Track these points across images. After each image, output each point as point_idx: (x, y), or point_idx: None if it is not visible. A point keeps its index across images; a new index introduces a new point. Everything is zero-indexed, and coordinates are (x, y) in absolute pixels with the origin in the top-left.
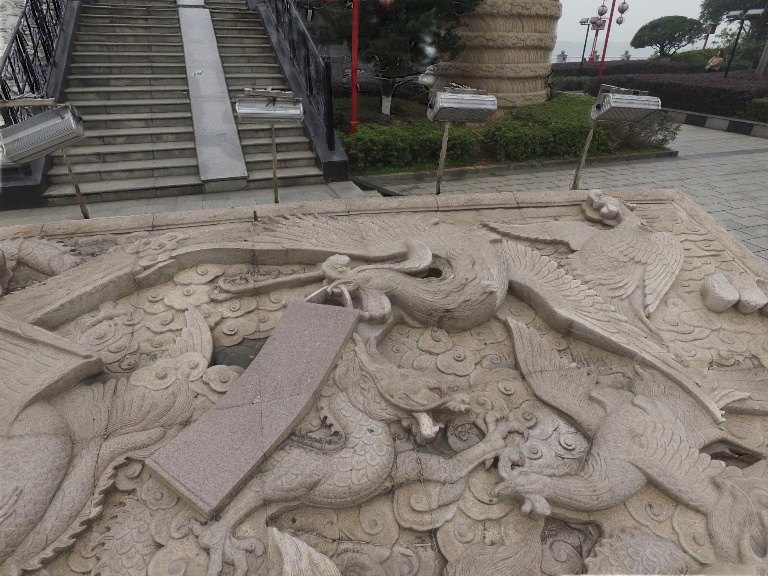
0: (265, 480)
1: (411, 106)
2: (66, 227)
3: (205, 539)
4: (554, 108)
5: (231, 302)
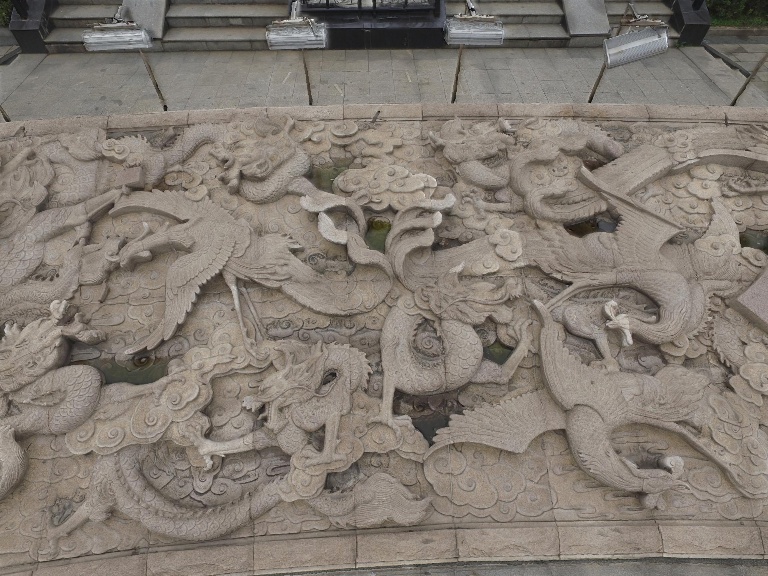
0: None
1: None
2: (591, 111)
3: None
4: None
5: (735, 199)
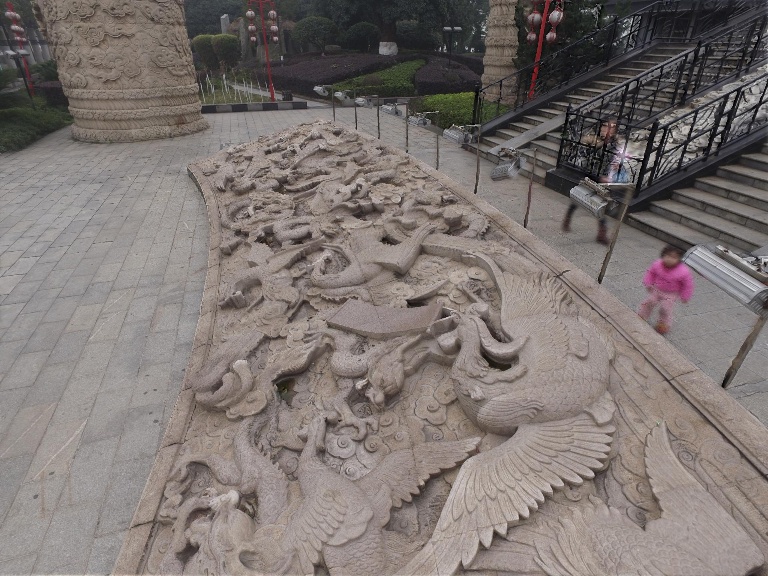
0: (341, 334)
1: None
2: (505, 222)
3: None
4: None
5: None
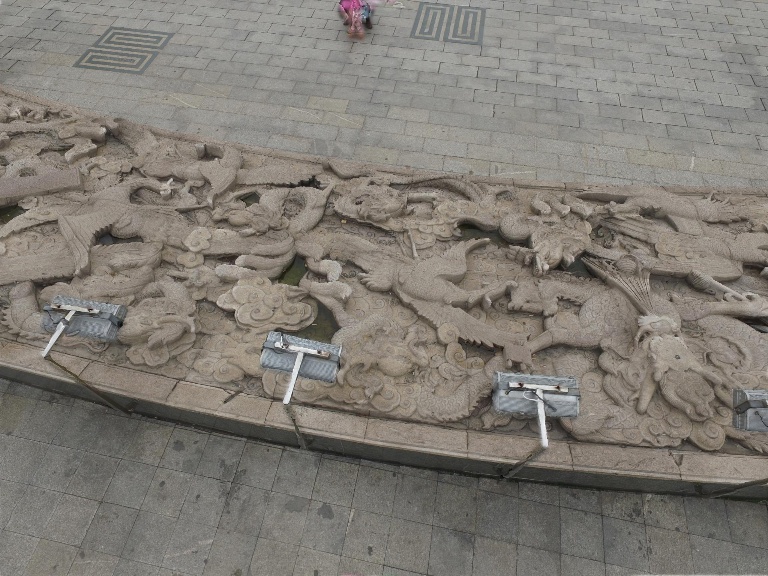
0: None
1: None
2: None
3: (86, 170)
4: None
5: None
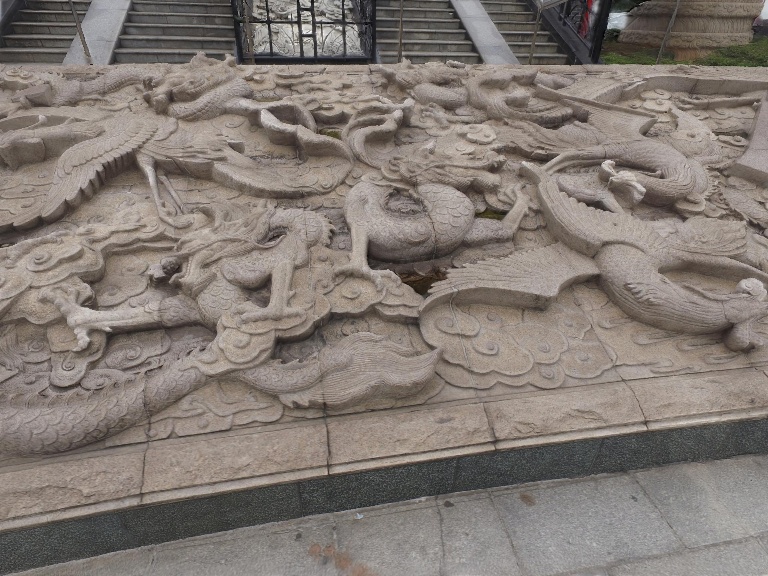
0: None
1: (611, 44)
2: None
3: None
4: (766, 48)
5: (691, 111)
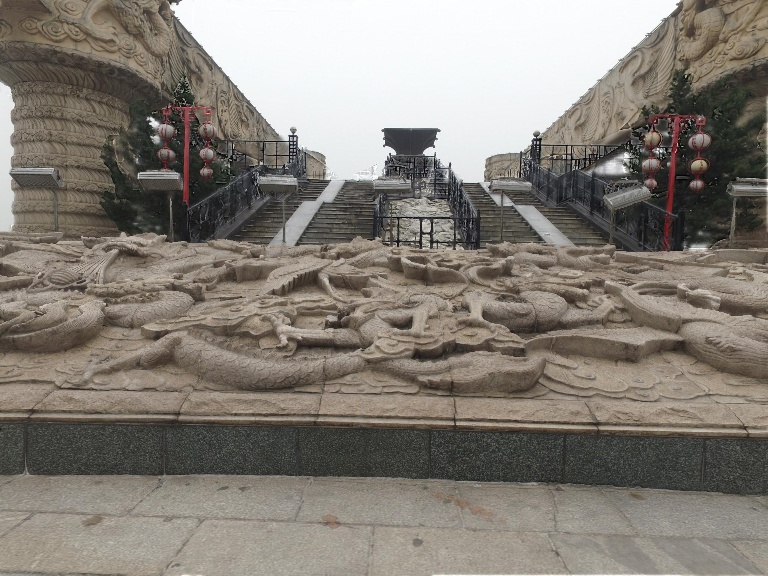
0: None
1: None
2: None
3: None
4: None
5: None
